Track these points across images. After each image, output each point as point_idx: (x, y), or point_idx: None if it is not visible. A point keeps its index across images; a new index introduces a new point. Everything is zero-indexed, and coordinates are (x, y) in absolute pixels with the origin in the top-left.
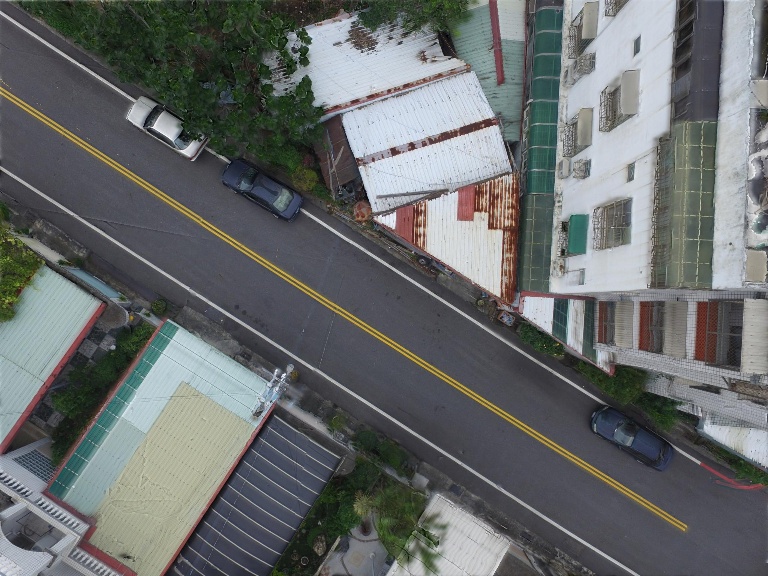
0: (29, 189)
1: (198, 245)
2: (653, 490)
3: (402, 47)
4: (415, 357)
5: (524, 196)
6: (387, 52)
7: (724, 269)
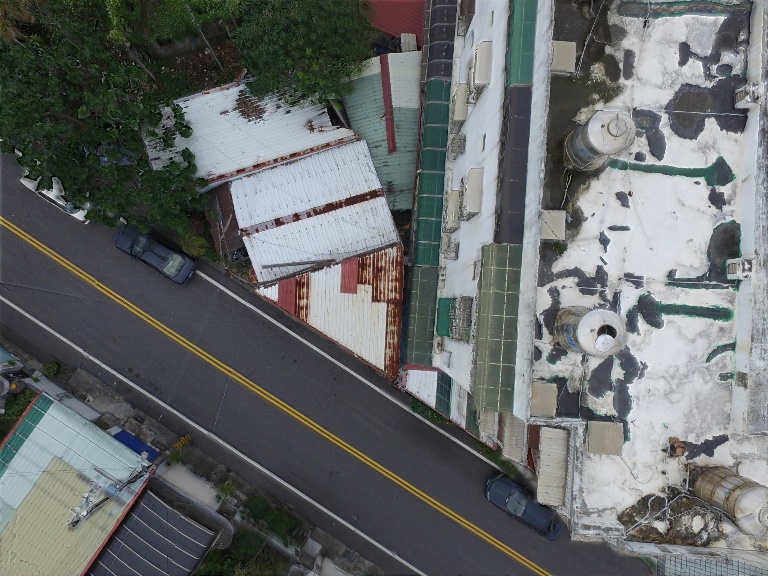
0: None
1: (92, 307)
2: (549, 558)
3: (290, 116)
4: (310, 422)
5: (412, 267)
6: (275, 121)
7: (519, 399)
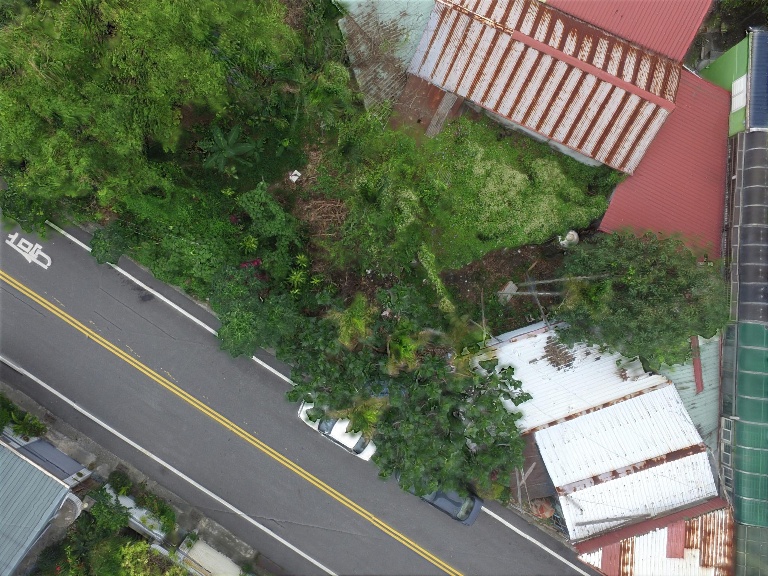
0: (195, 487)
1: (370, 545)
2: None
3: (600, 363)
4: None
5: None
6: (585, 369)
7: None
